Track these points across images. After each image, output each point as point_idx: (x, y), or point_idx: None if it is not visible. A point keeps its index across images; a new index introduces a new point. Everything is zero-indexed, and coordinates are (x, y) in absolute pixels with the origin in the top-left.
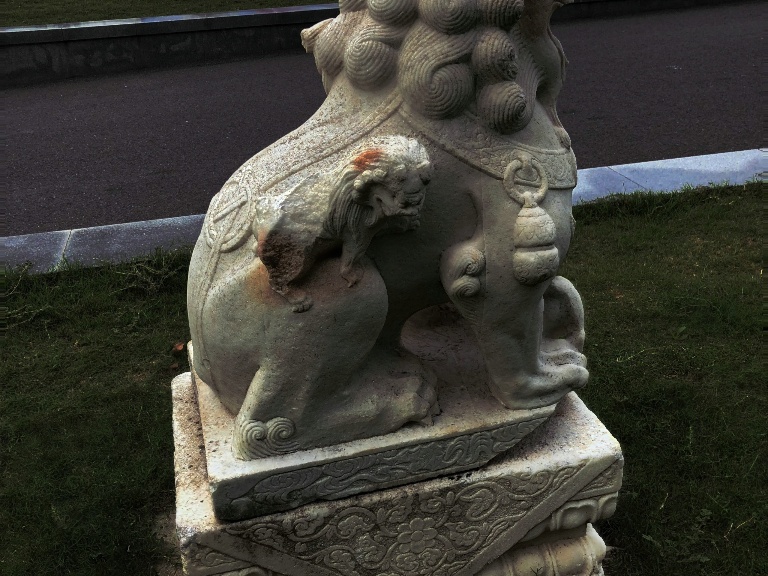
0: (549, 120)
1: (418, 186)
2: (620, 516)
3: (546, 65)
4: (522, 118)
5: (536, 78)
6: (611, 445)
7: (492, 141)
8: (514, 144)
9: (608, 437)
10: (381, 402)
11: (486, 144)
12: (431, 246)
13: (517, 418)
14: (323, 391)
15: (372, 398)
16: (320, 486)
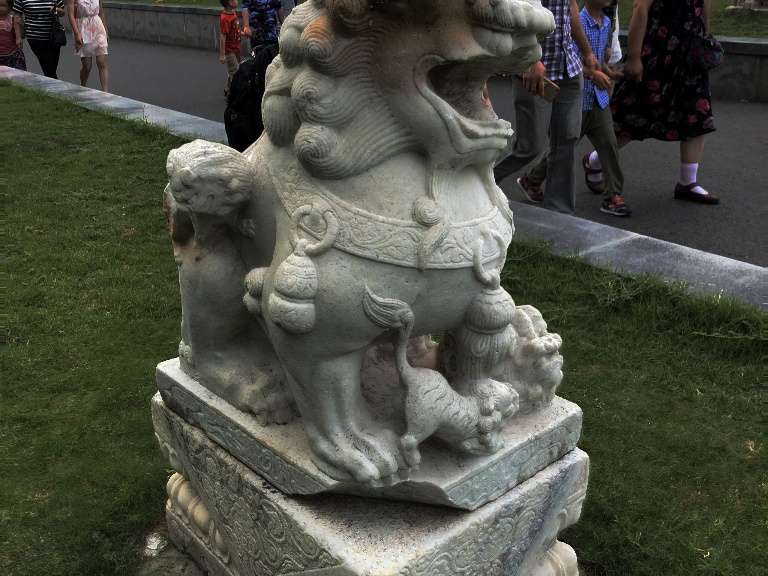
0: (422, 187)
1: (179, 186)
2: None
3: (410, 123)
4: (323, 165)
5: (395, 134)
6: (374, 569)
7: (301, 179)
8: (320, 190)
9: (388, 564)
10: (235, 378)
11: (294, 180)
12: (265, 260)
13: (304, 467)
14: (200, 340)
15: (232, 371)
16: (200, 418)
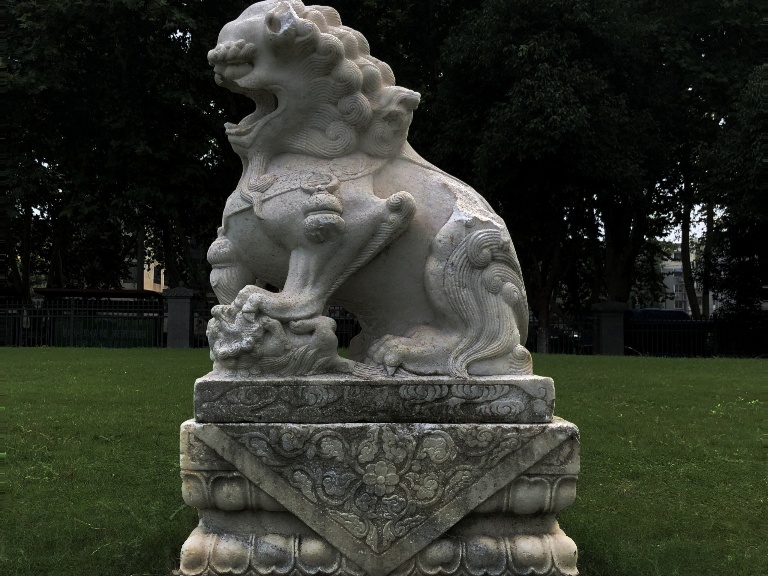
0: None
1: None
2: (152, 558)
3: None
4: None
5: None
6: None
7: None
8: None
9: None
10: None
11: None
12: None
13: None
14: None
15: None
16: None
